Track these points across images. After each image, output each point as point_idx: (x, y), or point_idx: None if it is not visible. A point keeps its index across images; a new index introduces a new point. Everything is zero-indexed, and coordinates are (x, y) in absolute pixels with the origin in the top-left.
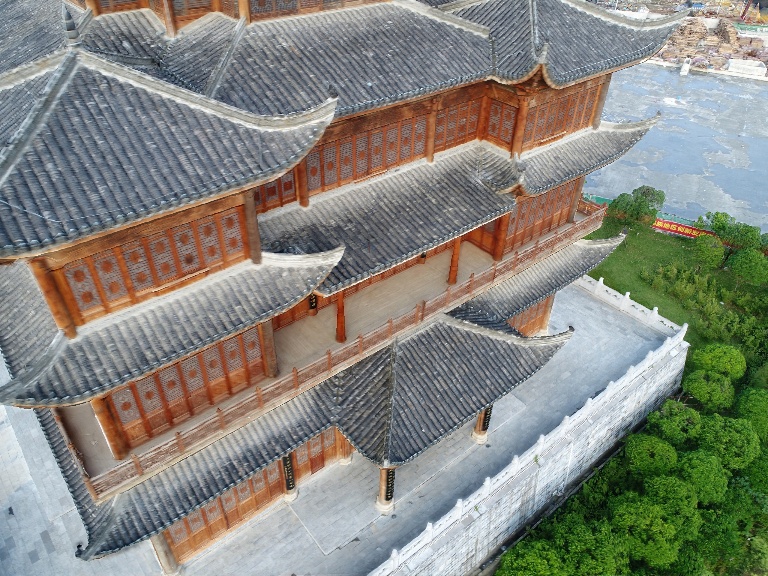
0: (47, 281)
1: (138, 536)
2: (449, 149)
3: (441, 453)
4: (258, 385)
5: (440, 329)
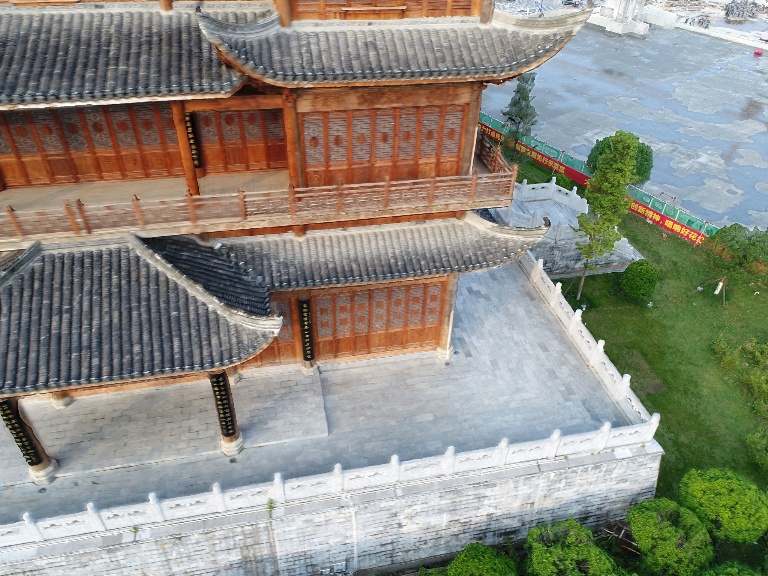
0: None
1: None
2: (211, 1)
3: (166, 442)
4: None
5: (122, 255)
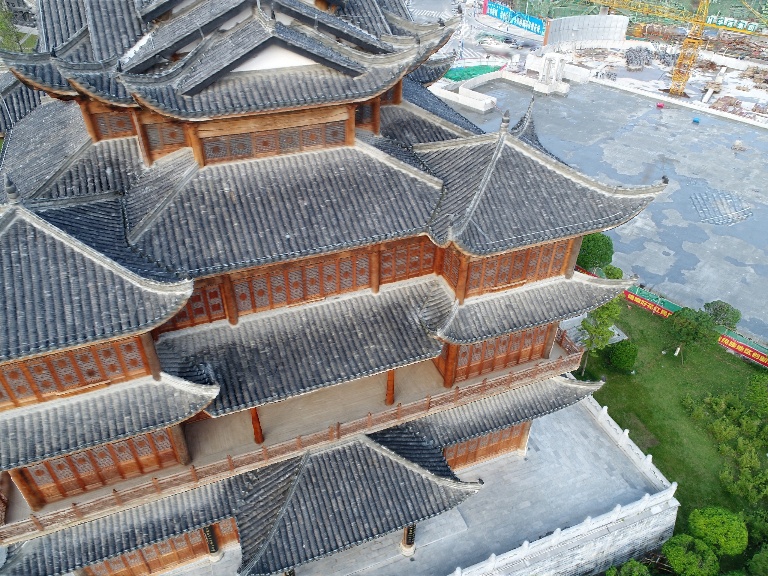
0: None
1: (37, 575)
2: (400, 281)
3: (363, 554)
4: (169, 469)
5: (358, 449)
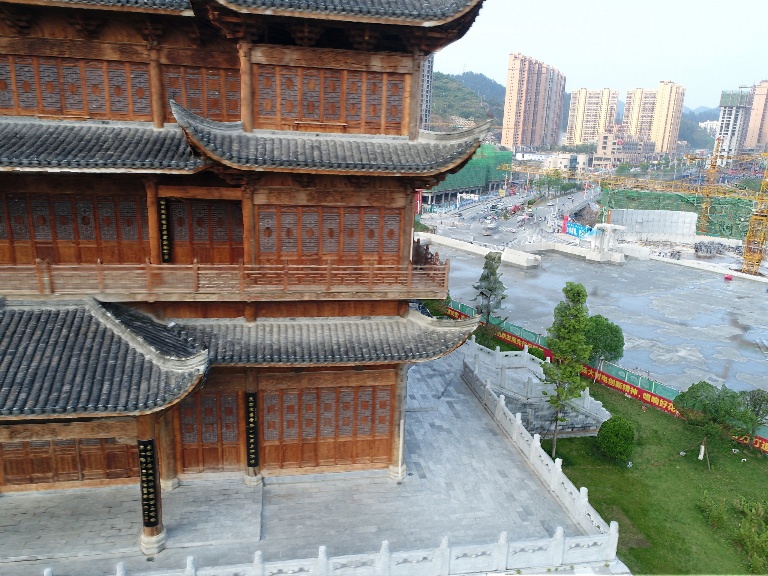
0: None
1: None
2: None
3: (83, 537)
4: None
5: (77, 315)
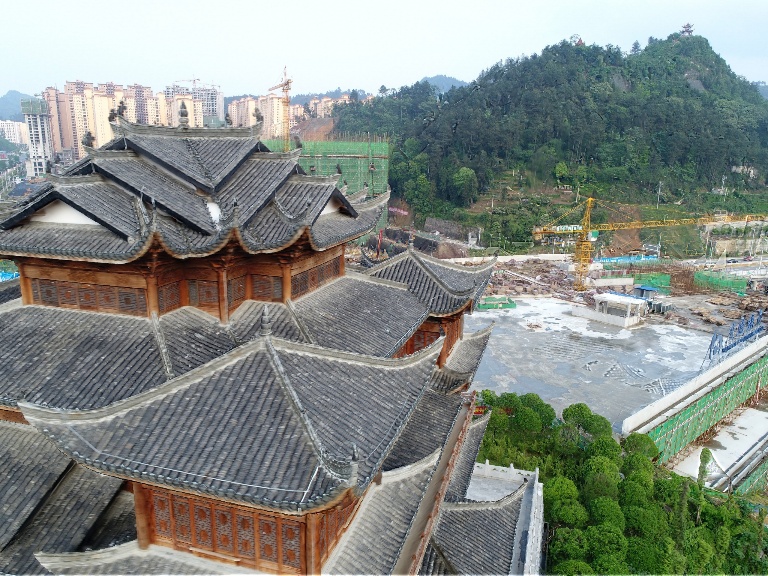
0: (318, 531)
1: None
2: None
3: None
4: None
5: (447, 516)
